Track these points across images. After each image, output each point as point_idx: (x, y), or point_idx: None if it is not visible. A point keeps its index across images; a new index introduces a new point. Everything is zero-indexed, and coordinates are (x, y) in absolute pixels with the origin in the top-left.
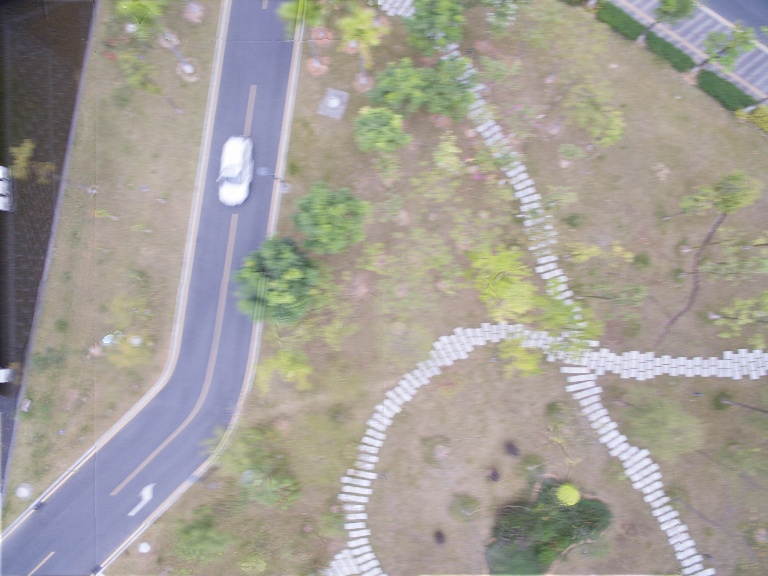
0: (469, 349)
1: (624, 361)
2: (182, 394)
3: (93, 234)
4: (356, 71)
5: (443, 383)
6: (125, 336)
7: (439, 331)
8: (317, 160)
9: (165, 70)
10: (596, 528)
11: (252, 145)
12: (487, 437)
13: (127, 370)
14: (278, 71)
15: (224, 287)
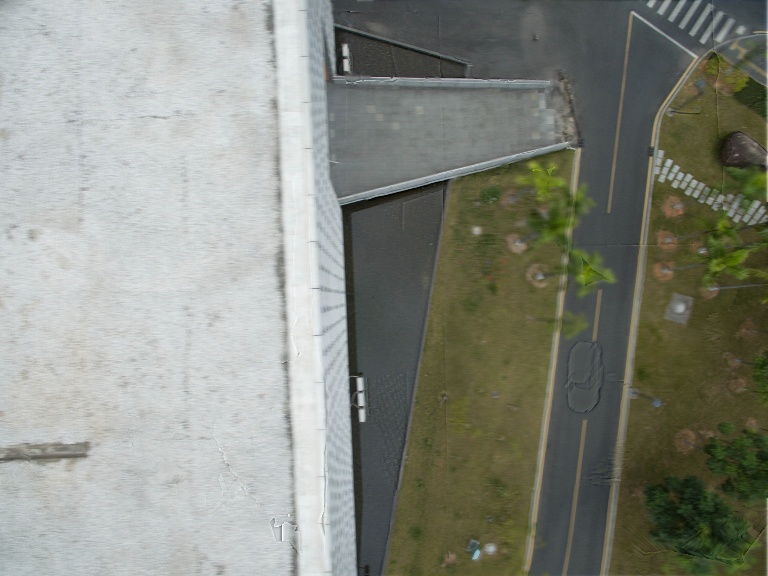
0: None
1: None
2: None
3: (445, 442)
4: (703, 277)
5: None
6: (481, 545)
7: None
8: (667, 367)
9: (513, 275)
10: None
11: (600, 350)
12: None
13: None
14: (624, 276)
15: (576, 494)
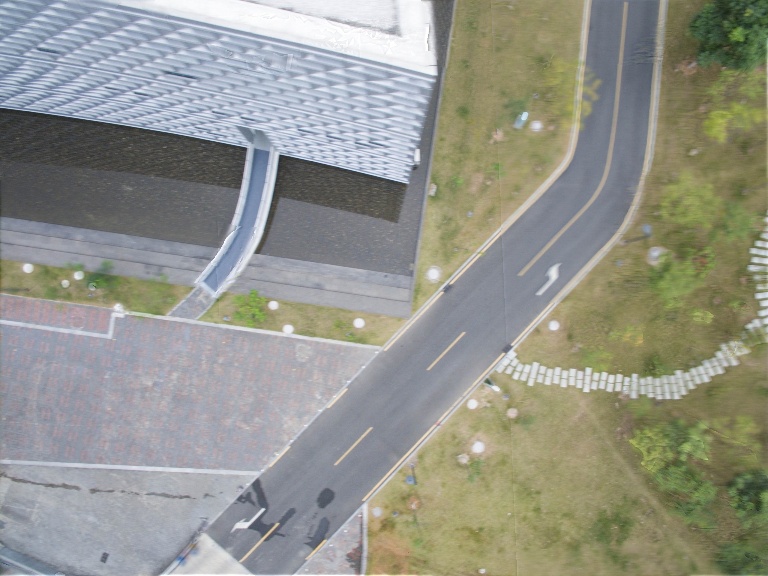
0: None
1: None
2: (585, 176)
3: (490, 24)
4: None
5: None
6: (528, 120)
7: None
8: None
9: None
10: None
11: None
12: None
13: (529, 154)
14: None
15: (620, 72)
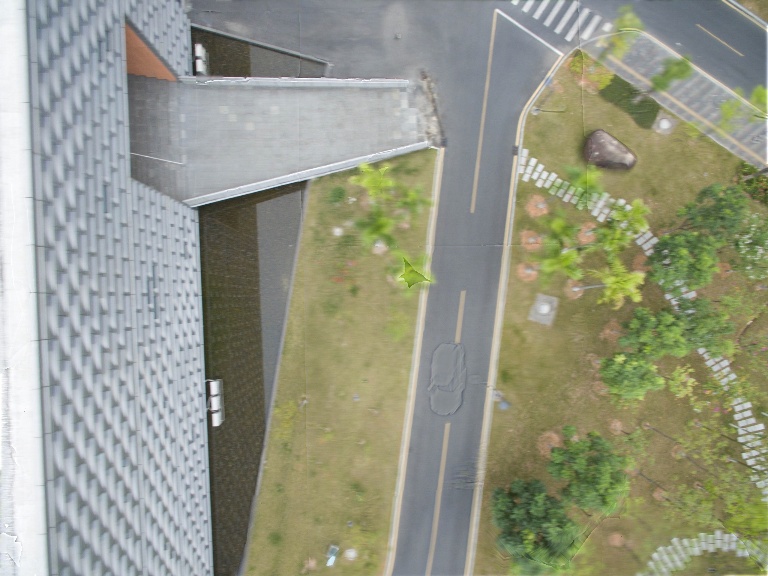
0: (686, 559)
1: None
2: None
3: (305, 446)
4: (567, 277)
5: None
6: (341, 551)
7: (657, 542)
8: (531, 369)
9: (374, 276)
10: None
11: (463, 352)
12: None
13: None
14: (488, 276)
15: (438, 498)
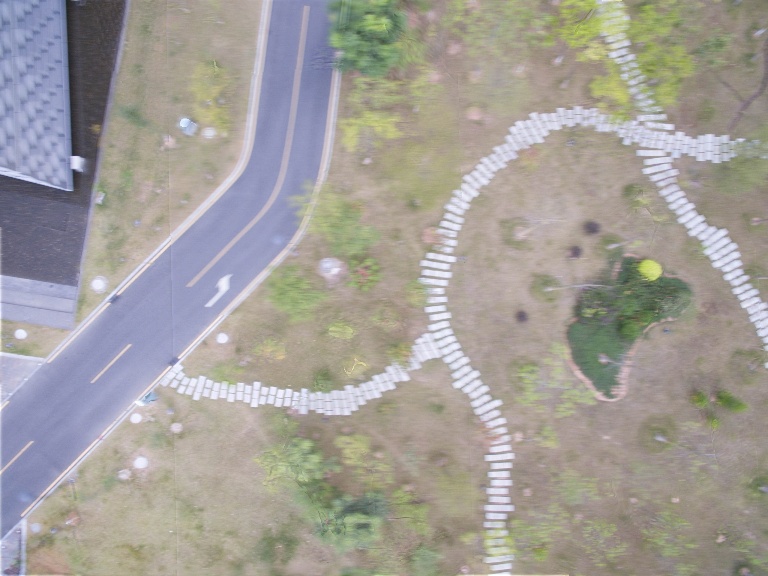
0: (545, 134)
1: (700, 144)
2: (257, 184)
3: (165, 27)
4: None
5: (521, 166)
6: (199, 127)
7: (515, 116)
8: None
9: None
10: (678, 304)
11: None
12: (566, 218)
13: (201, 162)
14: None
15: (297, 78)
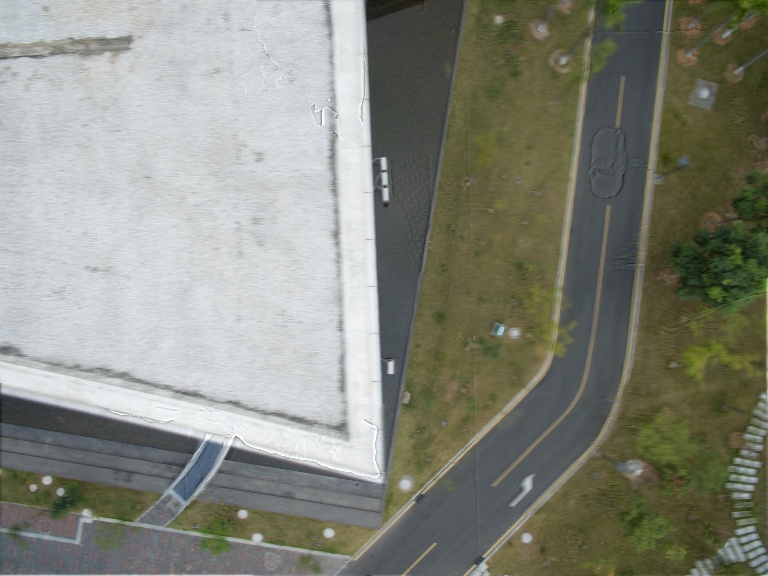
0: None
1: None
2: (561, 385)
3: (468, 227)
4: (727, 62)
5: None
6: (505, 328)
7: None
8: (692, 151)
9: (535, 62)
10: None
11: (623, 136)
12: None
13: (505, 362)
14: (647, 62)
15: (600, 279)
